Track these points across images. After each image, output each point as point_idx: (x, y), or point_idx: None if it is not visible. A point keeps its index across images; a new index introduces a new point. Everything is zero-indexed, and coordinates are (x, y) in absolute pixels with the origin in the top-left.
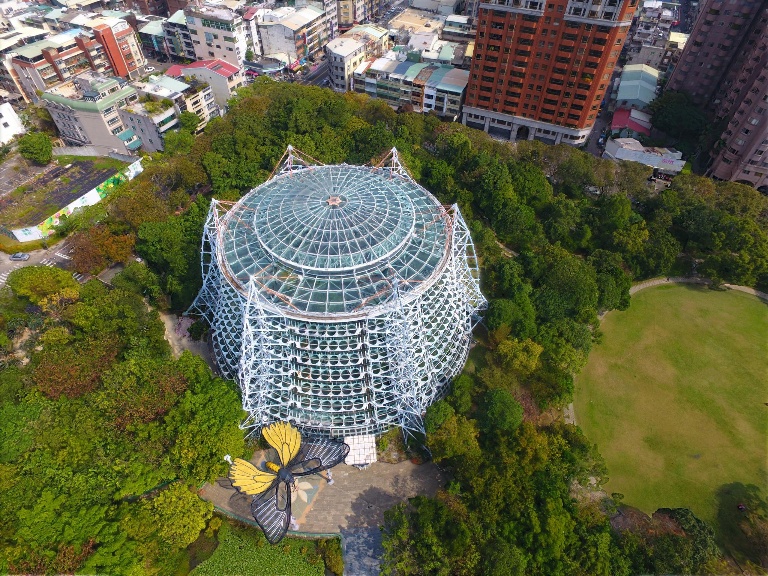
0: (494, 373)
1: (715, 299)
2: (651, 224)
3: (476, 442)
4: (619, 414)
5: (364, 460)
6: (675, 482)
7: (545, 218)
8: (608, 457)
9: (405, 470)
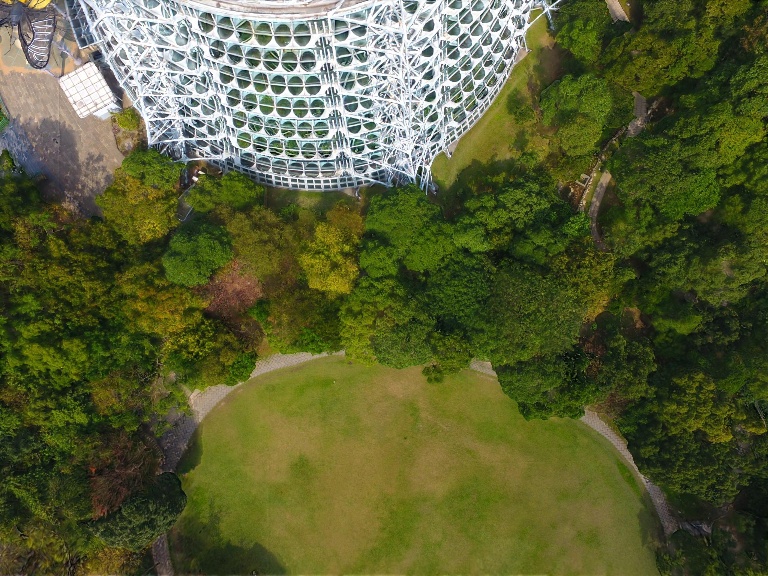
0: (274, 230)
1: (633, 557)
2: (760, 445)
3: (149, 234)
4: (329, 421)
5: (72, 101)
6: (257, 496)
7: (700, 236)
8: (256, 412)
9: (117, 165)
